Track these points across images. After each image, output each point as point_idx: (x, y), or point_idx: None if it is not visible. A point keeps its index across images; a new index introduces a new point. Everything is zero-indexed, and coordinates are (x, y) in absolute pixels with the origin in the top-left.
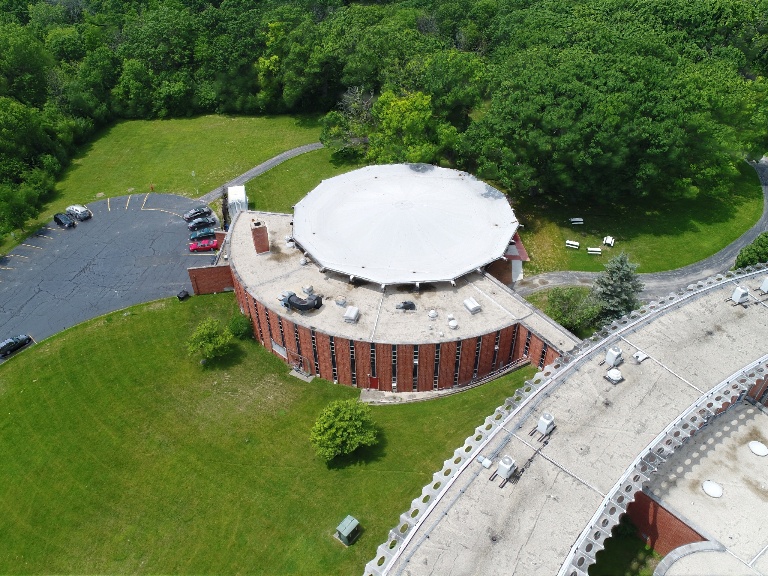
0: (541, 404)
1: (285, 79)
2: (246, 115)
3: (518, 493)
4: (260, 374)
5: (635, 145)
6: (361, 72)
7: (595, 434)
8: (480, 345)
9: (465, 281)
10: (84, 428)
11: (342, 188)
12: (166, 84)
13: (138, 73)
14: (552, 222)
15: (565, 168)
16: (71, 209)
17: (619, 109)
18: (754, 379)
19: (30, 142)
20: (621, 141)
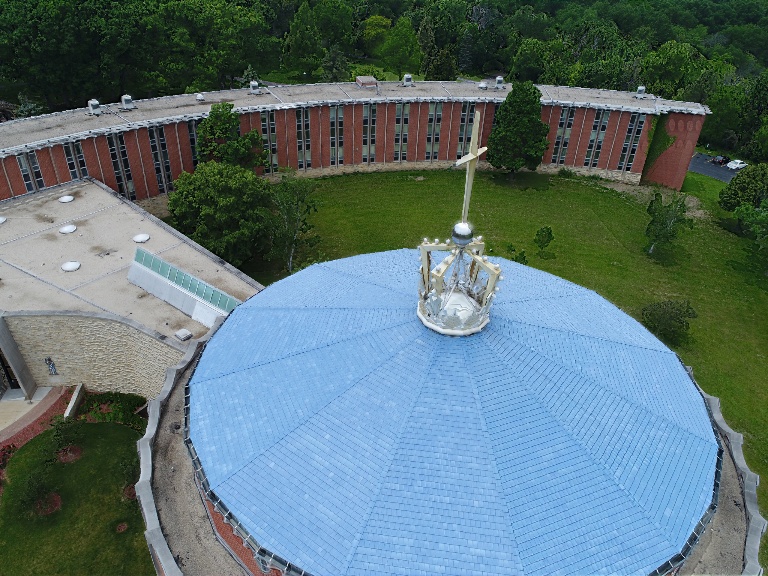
0: None
1: None
2: None
3: None
4: None
5: (87, 38)
6: None
7: None
8: None
9: None
10: None
11: None
12: None
13: None
14: None
15: (30, 62)
16: None
17: (58, 5)
18: (53, 144)
19: None
20: (65, 31)
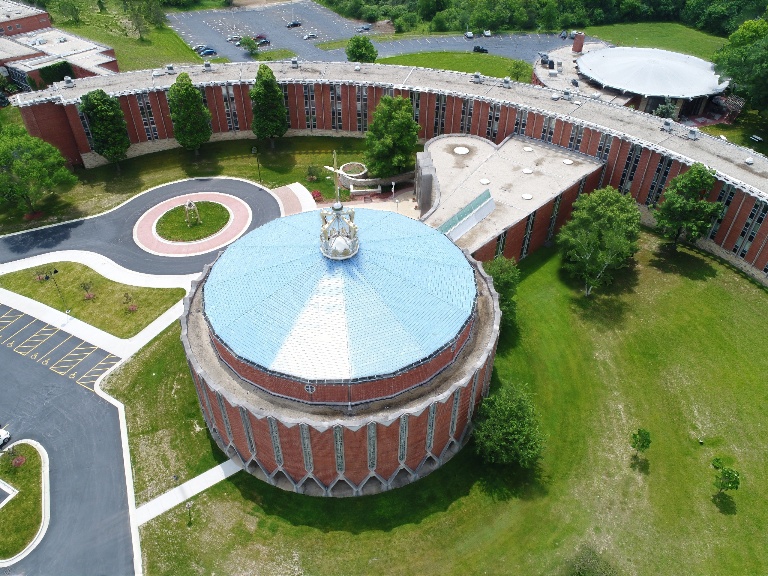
0: None
1: (763, 16)
2: None
3: None
4: None
5: None
6: None
7: (514, 95)
8: None
9: (616, 95)
10: None
11: (658, 55)
12: (714, 6)
13: None
14: (743, 133)
15: (754, 80)
16: None
17: None
18: (594, 128)
19: (601, 1)
20: None
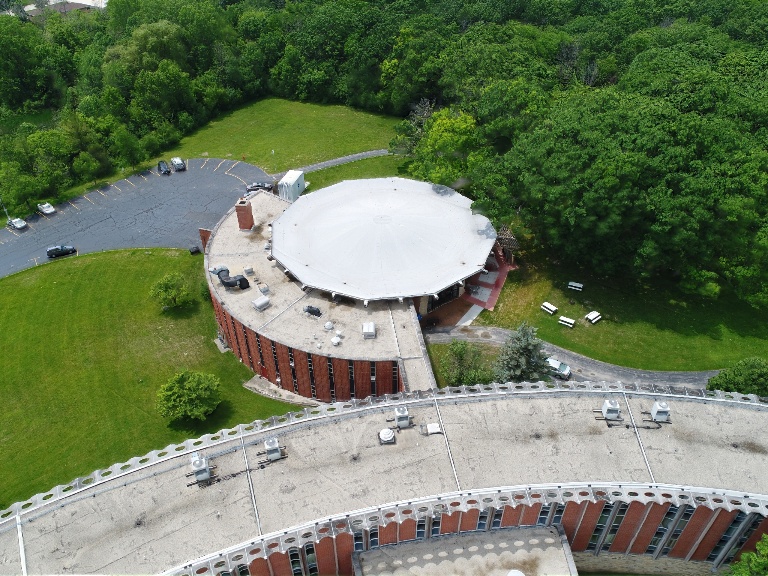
0: (295, 432)
1: (394, 83)
2: (367, 111)
3: (195, 497)
4: (194, 332)
5: (638, 216)
6: (450, 87)
7: (313, 479)
8: (353, 369)
9: (387, 306)
10: (54, 328)
11: (356, 192)
12: (310, 71)
13: (293, 58)
14: (550, 280)
15: (555, 223)
16: (173, 160)
17: (621, 171)
18: (533, 500)
19: (177, 100)
20: (614, 207)
